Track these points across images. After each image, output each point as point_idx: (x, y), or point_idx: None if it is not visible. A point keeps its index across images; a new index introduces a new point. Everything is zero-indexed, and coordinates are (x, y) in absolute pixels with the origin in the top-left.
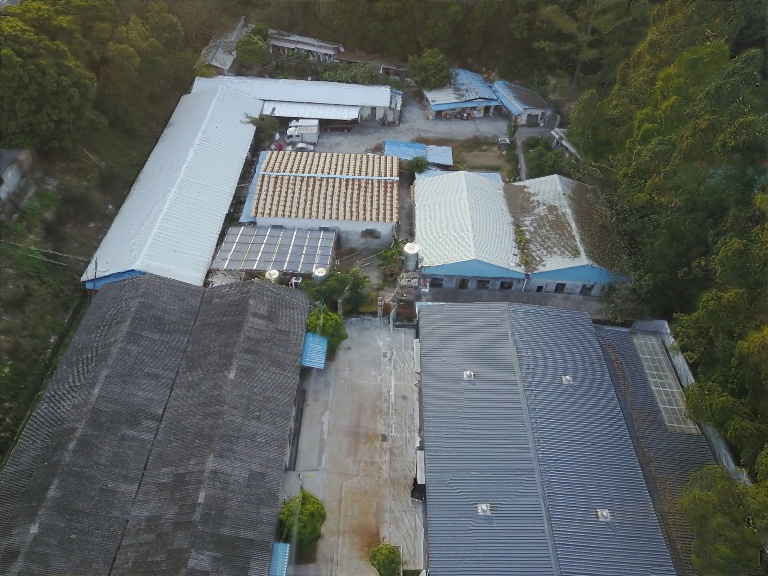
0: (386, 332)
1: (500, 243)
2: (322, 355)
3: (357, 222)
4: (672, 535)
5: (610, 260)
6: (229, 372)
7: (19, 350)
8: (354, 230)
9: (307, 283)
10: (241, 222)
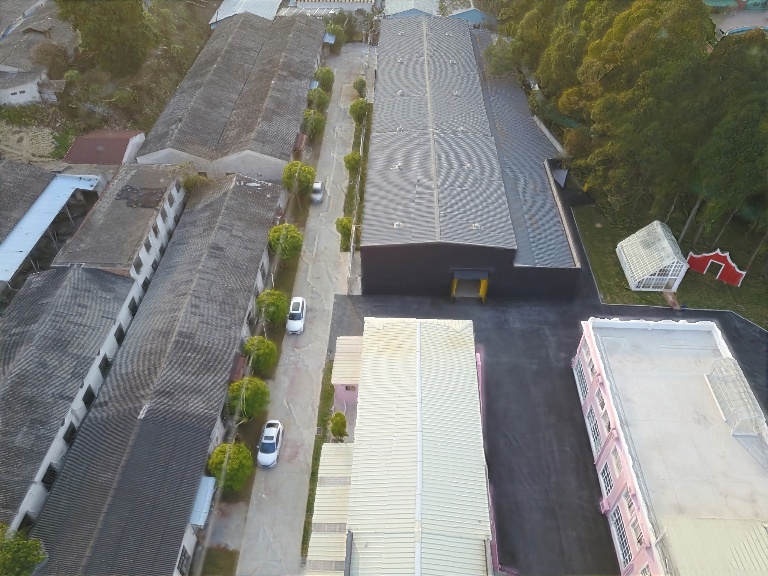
0: (367, 48)
1: (429, 6)
2: (333, 40)
3: (352, 4)
4: (485, 76)
5: (482, 1)
6: (289, 35)
7: (186, 42)
8: (351, 10)
9: (325, 17)
10: (289, 6)
